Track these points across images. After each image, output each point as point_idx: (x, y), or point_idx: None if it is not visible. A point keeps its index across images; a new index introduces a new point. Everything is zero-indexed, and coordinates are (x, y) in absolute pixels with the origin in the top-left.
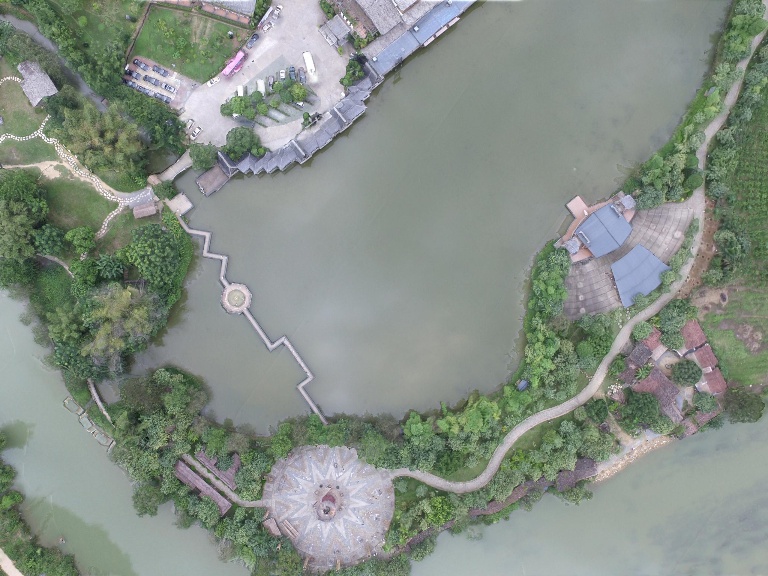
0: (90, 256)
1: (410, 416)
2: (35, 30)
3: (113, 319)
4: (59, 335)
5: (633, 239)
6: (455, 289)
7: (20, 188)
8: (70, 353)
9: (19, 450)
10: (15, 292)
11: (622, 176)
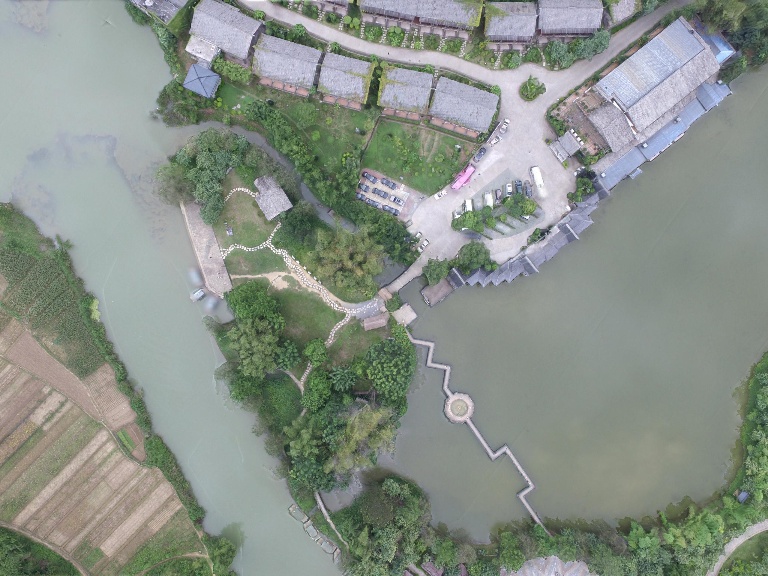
0: (318, 366)
1: (632, 527)
2: (263, 141)
3: (359, 438)
4: (299, 451)
5: None
6: (673, 399)
7: (266, 307)
8: (314, 470)
9: (239, 554)
10: (252, 405)
11: None
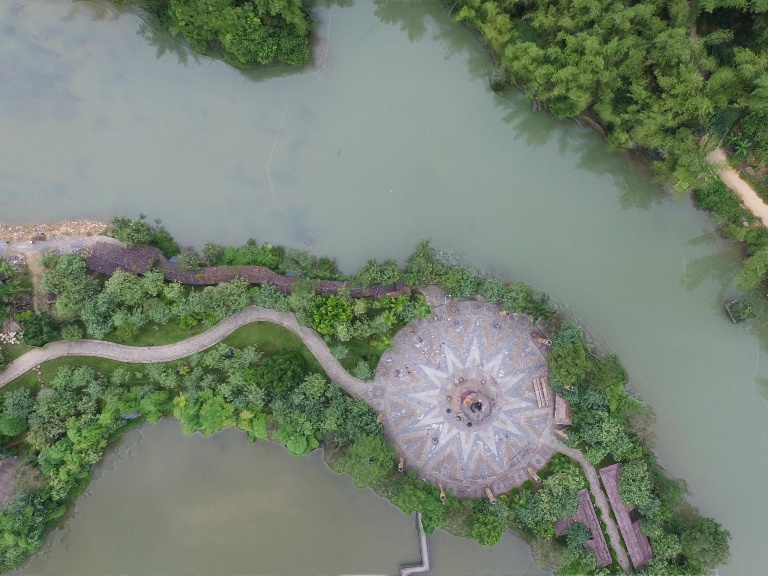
0: None
1: None
2: None
3: None
4: None
5: None
6: None
7: None
8: None
9: None
10: None
11: None
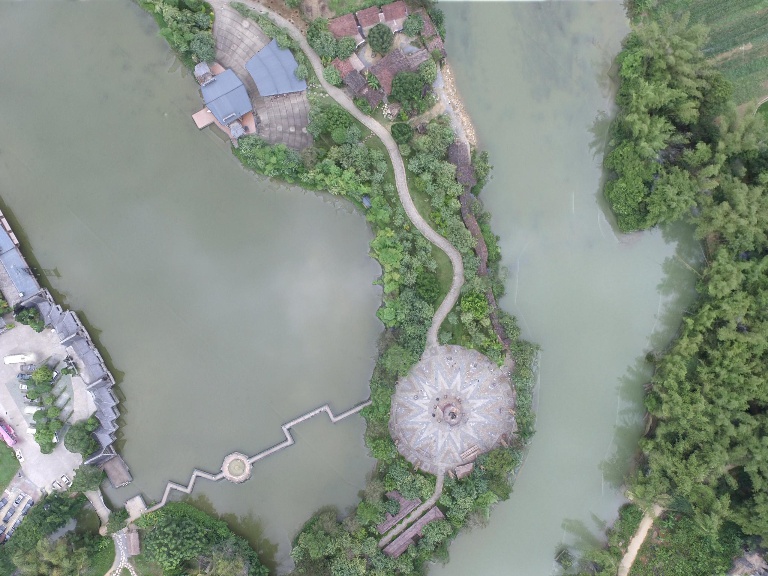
0: None
1: None
2: None
3: None
4: None
5: (243, 69)
6: (264, 252)
7: None
8: None
9: None
10: None
11: (181, 69)
